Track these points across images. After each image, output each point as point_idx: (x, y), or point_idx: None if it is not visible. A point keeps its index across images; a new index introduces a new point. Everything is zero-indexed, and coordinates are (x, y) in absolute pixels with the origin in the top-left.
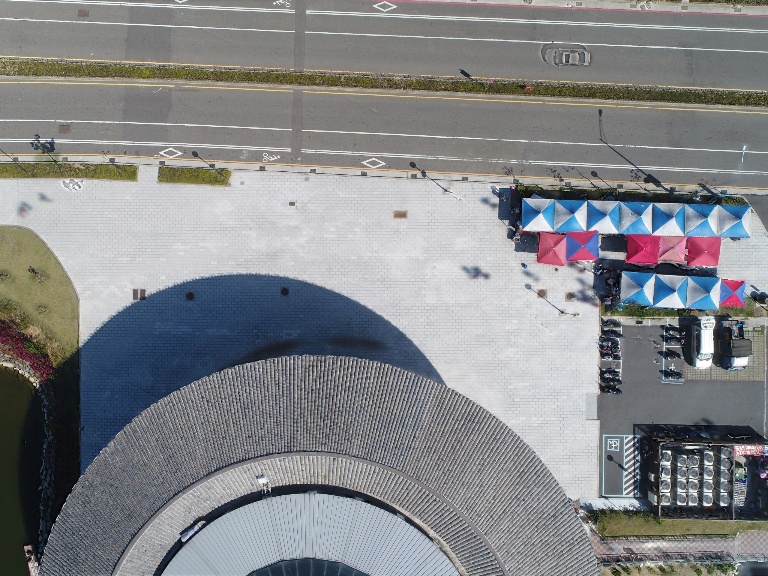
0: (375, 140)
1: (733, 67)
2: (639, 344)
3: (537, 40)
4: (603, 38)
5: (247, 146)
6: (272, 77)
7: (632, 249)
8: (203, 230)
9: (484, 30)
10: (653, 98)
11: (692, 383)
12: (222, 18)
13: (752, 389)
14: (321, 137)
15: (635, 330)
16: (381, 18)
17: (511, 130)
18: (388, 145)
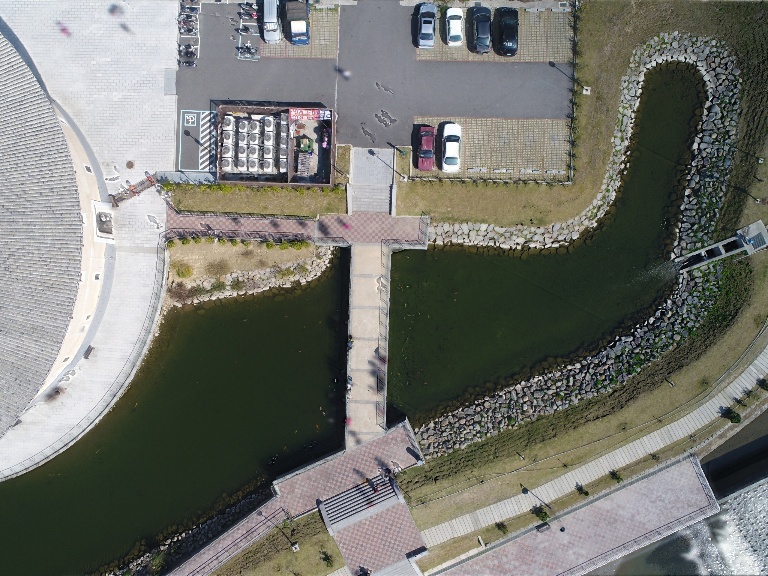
0: None
1: None
2: (217, 21)
3: None
4: None
5: None
6: None
7: None
8: None
9: None
10: None
11: (267, 60)
12: None
13: (324, 66)
14: None
15: (214, 8)
16: None
17: None
18: None
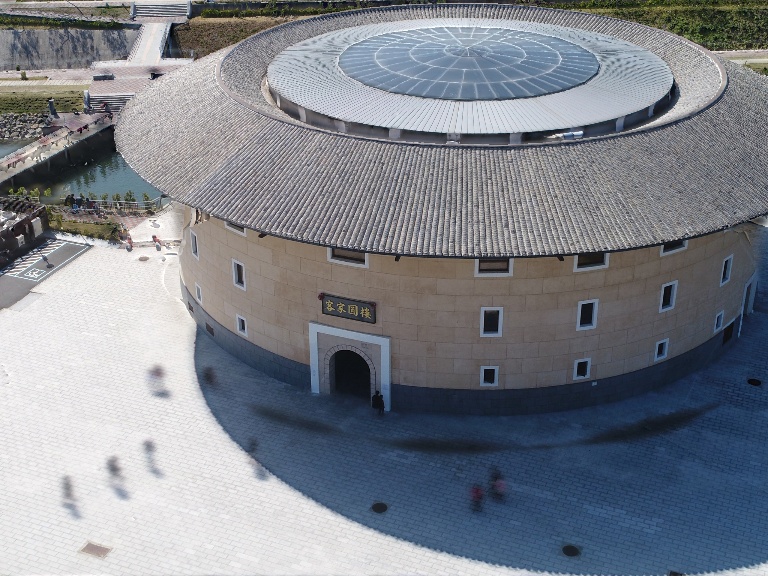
0: None
1: None
2: None
3: None
4: None
5: None
6: None
7: None
8: None
9: None
10: None
11: None
12: None
13: None
14: None
15: None
16: None
17: None
18: None
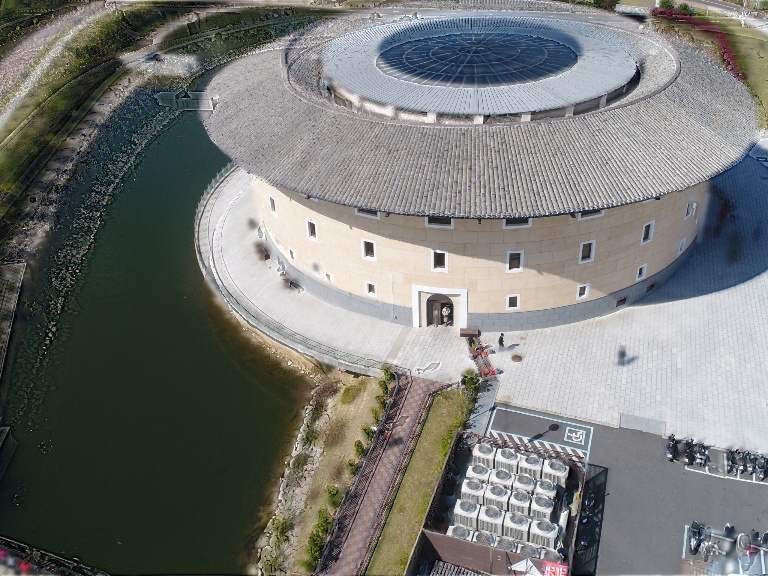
0: None
1: None
2: (762, 511)
3: None
4: None
5: None
6: None
7: None
8: None
9: None
10: None
11: (686, 575)
12: None
13: None
14: None
15: None
16: None
17: None
18: None
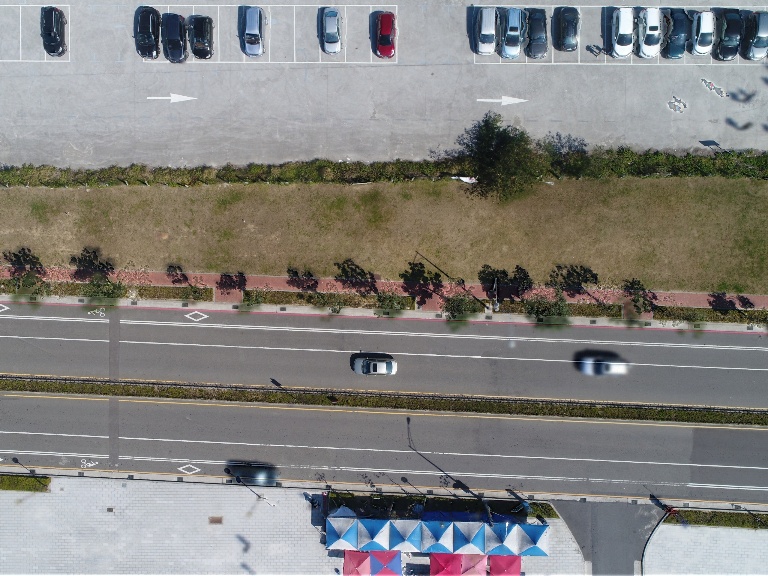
0: (190, 447)
1: (537, 376)
2: None
3: (345, 349)
4: (410, 347)
5: (66, 453)
6: (87, 388)
7: (434, 568)
8: (24, 535)
9: (293, 340)
10: (458, 408)
11: None
12: (38, 328)
13: None
14: (137, 444)
15: None
16: (193, 328)
17: (322, 438)
18: (203, 452)
